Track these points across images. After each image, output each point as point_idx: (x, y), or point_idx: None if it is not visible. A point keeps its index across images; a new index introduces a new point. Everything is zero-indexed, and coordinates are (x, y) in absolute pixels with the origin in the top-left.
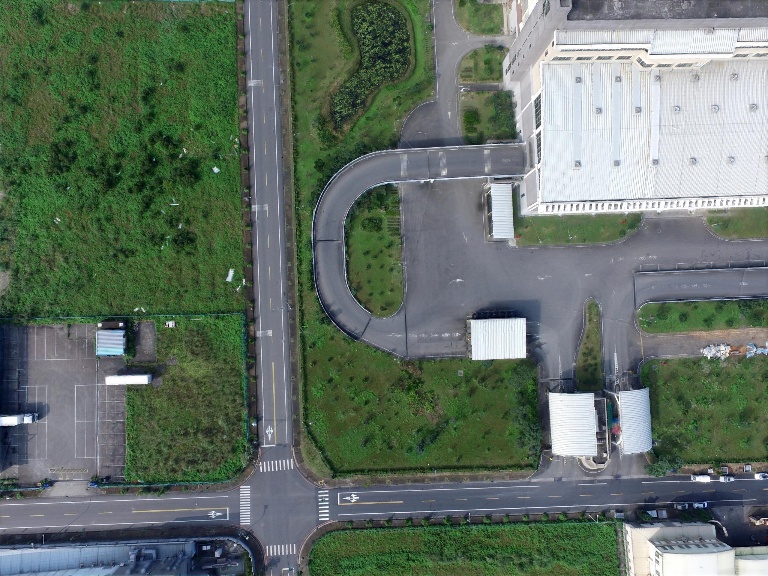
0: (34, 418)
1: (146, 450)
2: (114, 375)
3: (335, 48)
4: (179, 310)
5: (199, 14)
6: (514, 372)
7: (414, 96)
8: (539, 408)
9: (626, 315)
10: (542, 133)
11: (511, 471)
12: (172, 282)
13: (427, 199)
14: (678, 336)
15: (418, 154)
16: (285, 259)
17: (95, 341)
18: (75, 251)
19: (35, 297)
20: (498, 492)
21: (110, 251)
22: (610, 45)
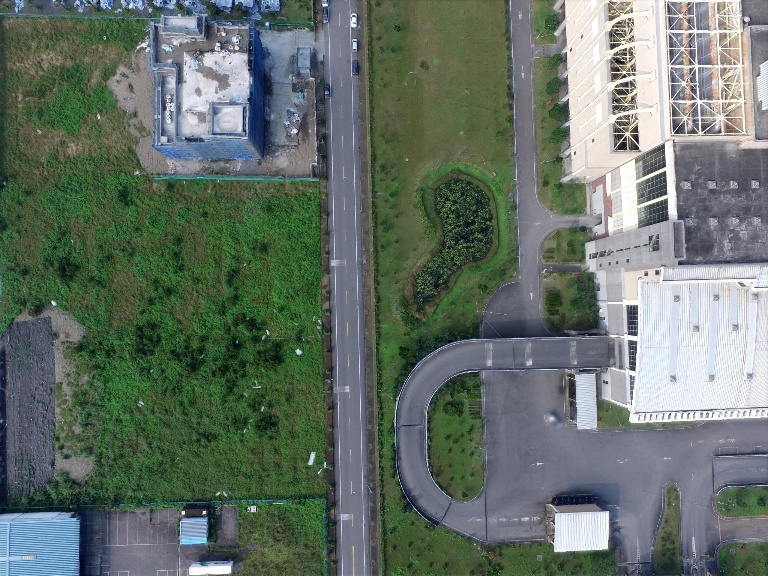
0: None
1: None
2: (196, 562)
3: (419, 229)
4: (261, 494)
5: (283, 194)
6: (595, 562)
7: (496, 277)
8: None
9: (704, 498)
10: (639, 350)
11: None
12: (254, 466)
13: (508, 381)
14: (755, 519)
15: (503, 343)
16: (366, 441)
17: (177, 527)
18: (158, 435)
19: (118, 483)
20: None
21: (193, 435)
22: (716, 280)
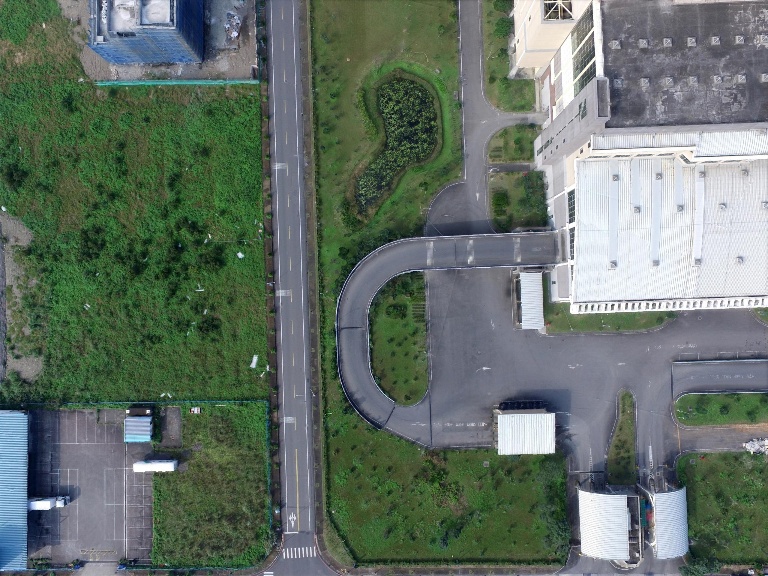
0: (66, 501)
1: (172, 534)
2: (141, 460)
3: (360, 129)
4: (204, 396)
5: (224, 97)
6: (542, 467)
7: (441, 178)
8: (568, 501)
9: (662, 406)
10: (576, 233)
11: (538, 565)
12: (197, 368)
13: (453, 284)
14: (718, 429)
15: (445, 242)
16: (309, 345)
17: (123, 426)
18: (104, 337)
19: (66, 382)
20: None
21: (137, 337)
22: (651, 149)
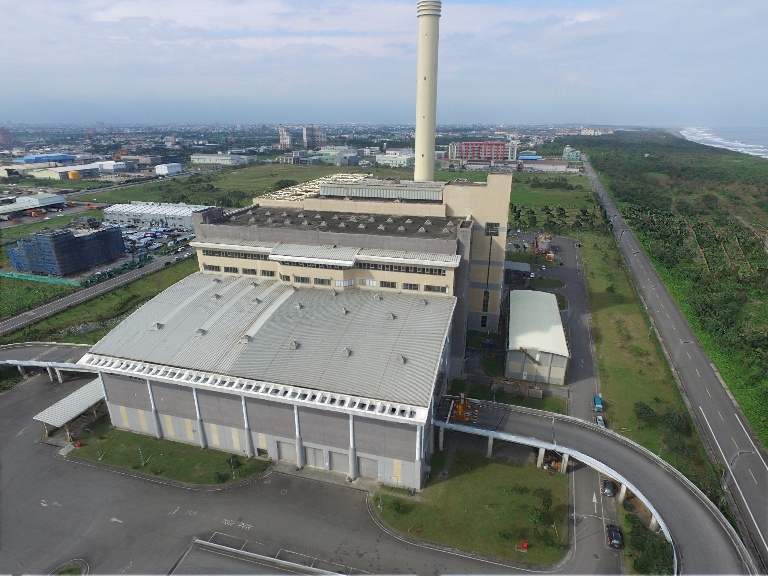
0: None
1: None
2: None
3: None
4: None
5: (50, 287)
6: None
7: None
8: None
9: None
10: None
11: None
12: None
13: (37, 393)
14: None
15: None
16: None
17: None
18: None
19: None
20: None
21: None
22: (236, 246)
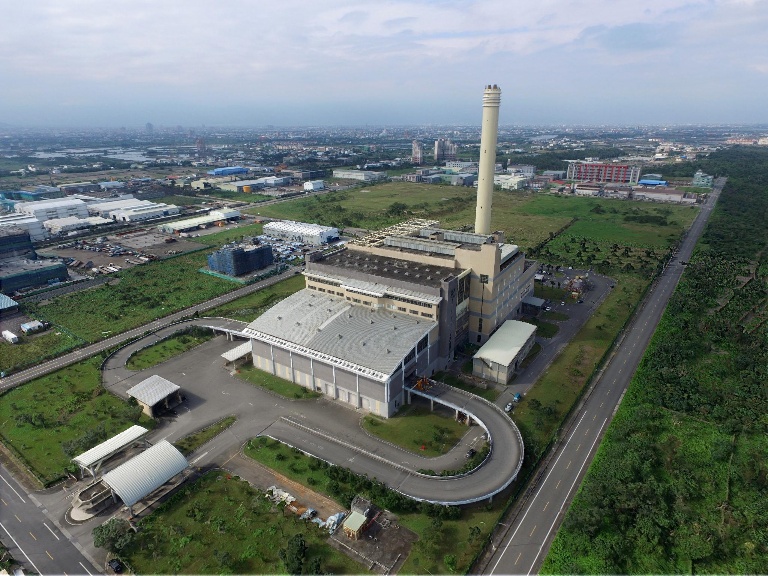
0: None
1: None
2: None
3: None
4: None
5: None
6: None
7: None
8: None
9: (245, 436)
10: None
11: (33, 478)
12: None
13: None
14: (263, 469)
15: (236, 323)
16: None
17: None
18: None
19: None
20: (2, 486)
21: None
22: (325, 277)
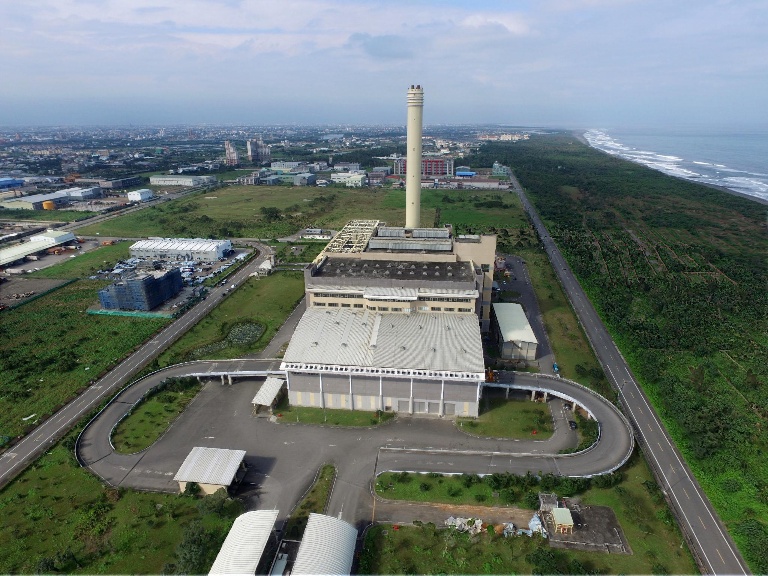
0: None
1: None
2: None
3: None
4: None
5: (148, 320)
6: None
7: (247, 351)
8: None
9: (363, 480)
10: None
11: None
12: None
13: (221, 392)
14: (418, 505)
15: (226, 363)
16: (82, 413)
17: None
18: None
19: None
20: None
21: None
22: (339, 290)
